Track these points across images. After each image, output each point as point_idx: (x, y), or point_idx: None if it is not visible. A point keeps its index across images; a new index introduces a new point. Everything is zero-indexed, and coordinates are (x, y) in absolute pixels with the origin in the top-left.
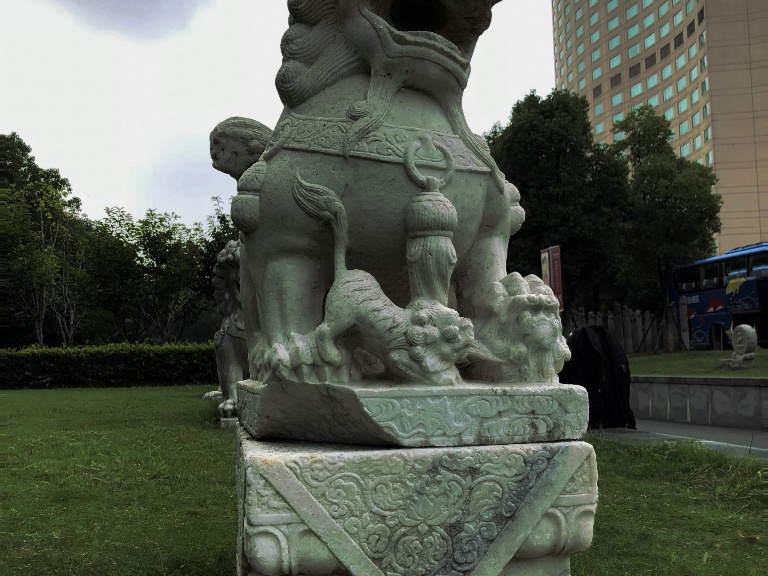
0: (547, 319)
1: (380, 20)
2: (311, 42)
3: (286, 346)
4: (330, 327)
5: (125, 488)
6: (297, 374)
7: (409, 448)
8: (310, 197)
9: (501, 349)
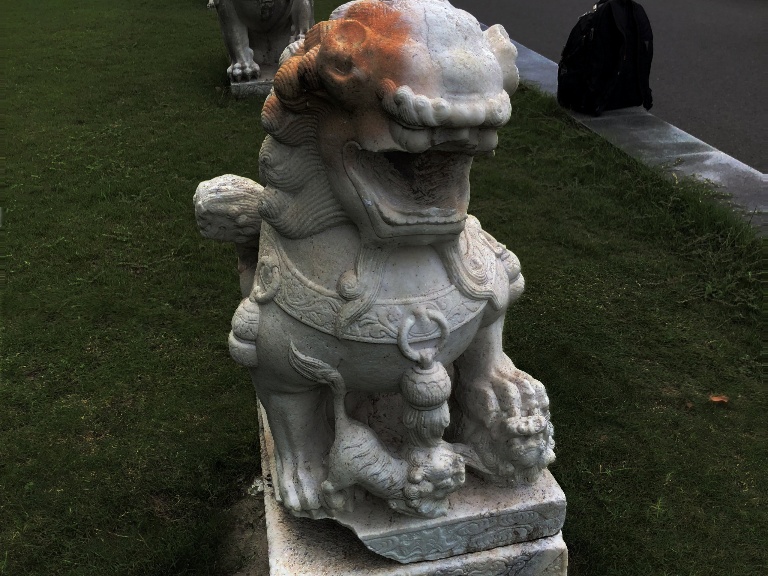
0: (534, 445)
1: (367, 193)
2: (293, 173)
3: (296, 487)
4: (334, 487)
5: (155, 282)
6: (308, 513)
7: (407, 564)
8: (306, 369)
9: (491, 464)
